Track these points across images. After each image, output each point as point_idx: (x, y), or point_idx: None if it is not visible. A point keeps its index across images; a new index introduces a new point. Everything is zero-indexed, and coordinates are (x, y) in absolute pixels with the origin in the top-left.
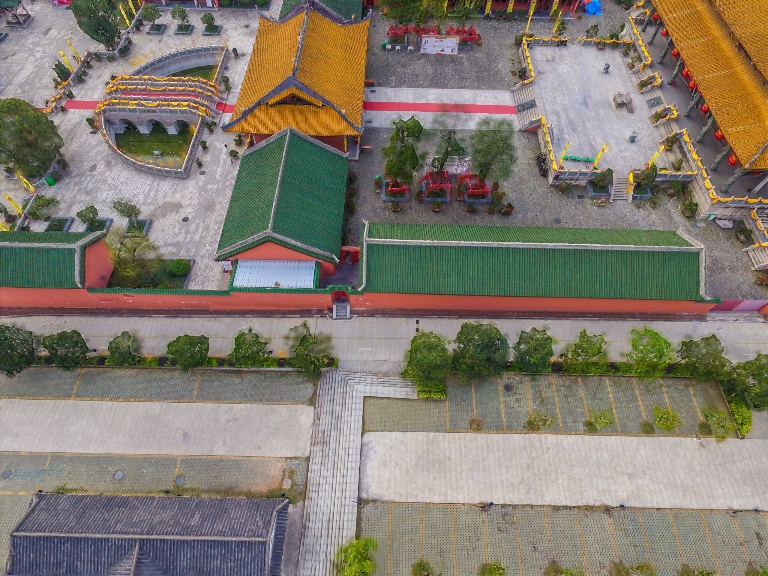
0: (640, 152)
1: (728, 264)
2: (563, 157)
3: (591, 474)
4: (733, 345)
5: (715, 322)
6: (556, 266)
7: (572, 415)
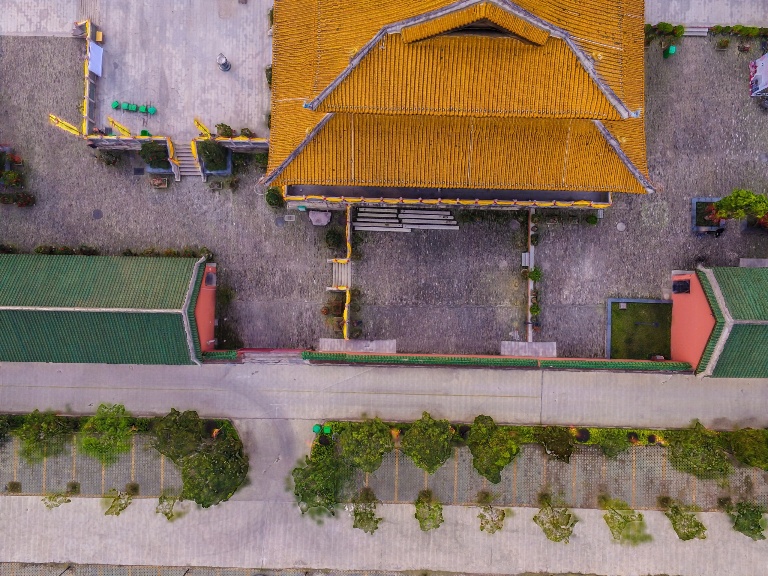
0: (232, 91)
1: (300, 282)
2: (111, 105)
3: (63, 535)
4: (262, 393)
5: (253, 364)
6: (6, 329)
7: (57, 476)
